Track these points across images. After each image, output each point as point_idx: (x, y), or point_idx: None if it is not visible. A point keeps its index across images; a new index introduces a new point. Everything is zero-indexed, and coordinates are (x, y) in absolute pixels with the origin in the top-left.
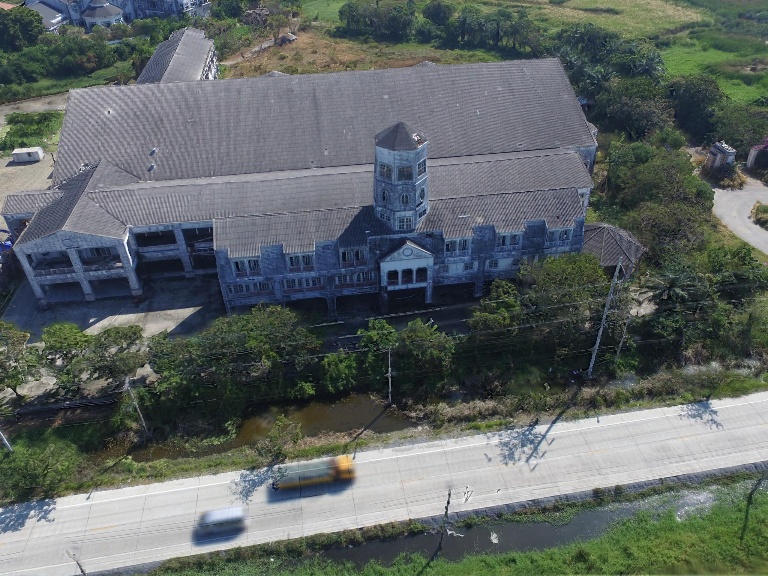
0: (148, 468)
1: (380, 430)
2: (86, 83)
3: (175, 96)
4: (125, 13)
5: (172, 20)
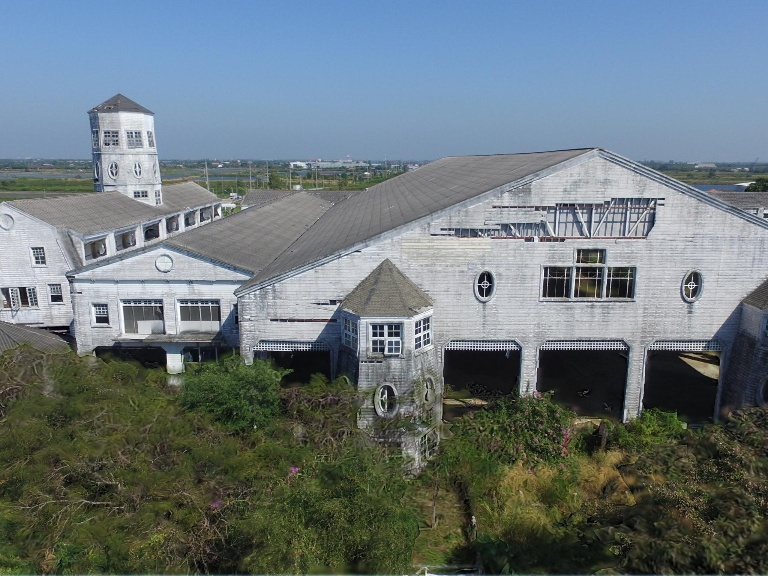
0: None
1: None
2: None
3: None
4: None
5: None
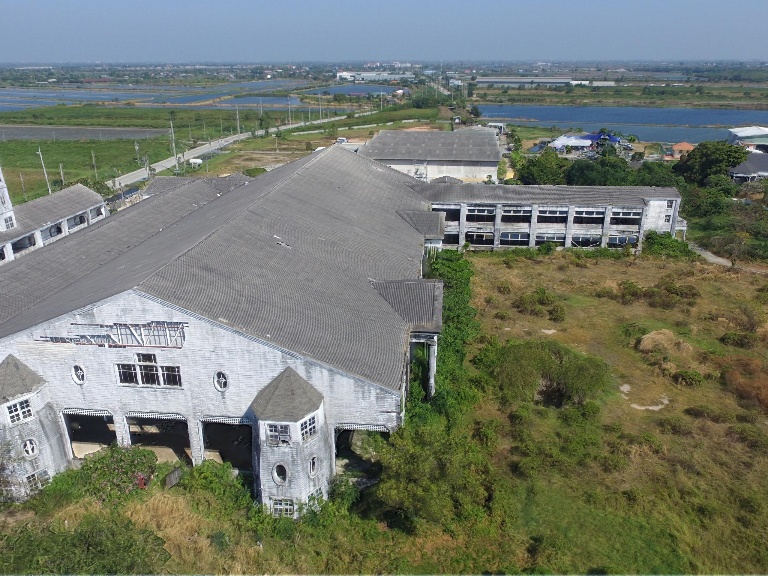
0: None
1: None
2: None
3: None
4: None
5: None
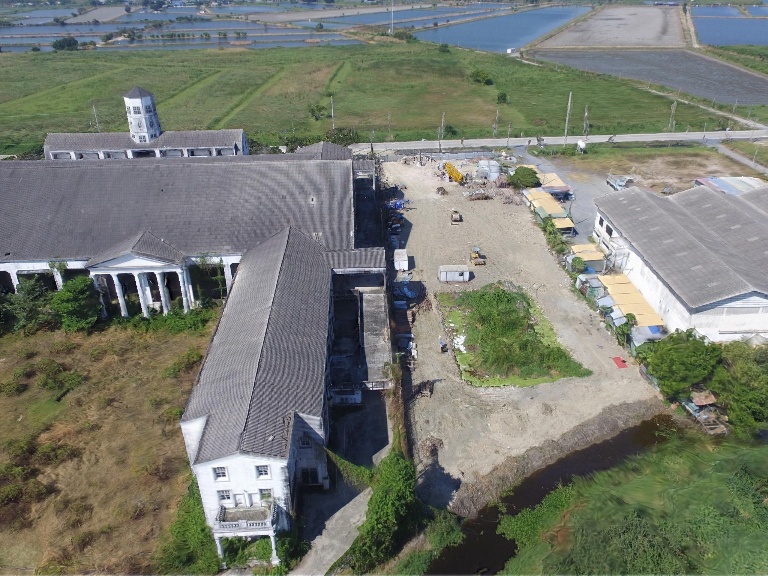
0: None
1: None
2: (550, 519)
3: None
4: None
5: None
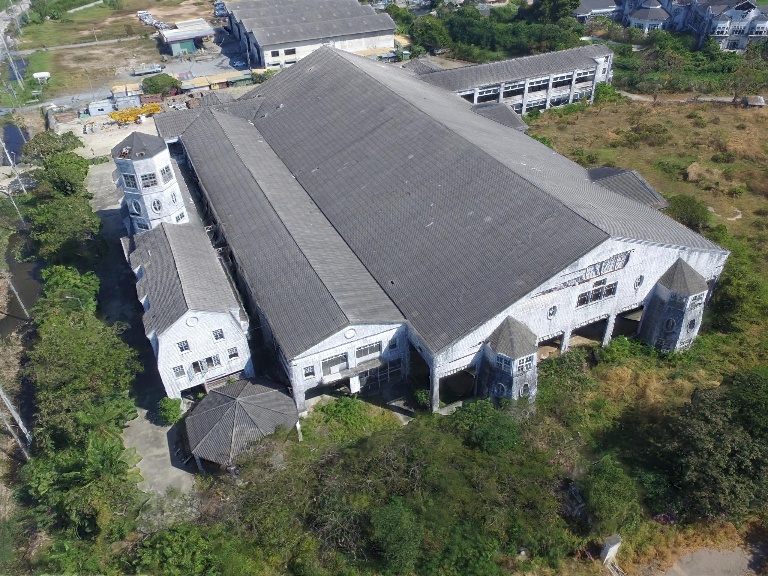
0: (2, 240)
1: (4, 321)
2: None
3: (341, 76)
4: (672, 21)
5: (685, 40)
